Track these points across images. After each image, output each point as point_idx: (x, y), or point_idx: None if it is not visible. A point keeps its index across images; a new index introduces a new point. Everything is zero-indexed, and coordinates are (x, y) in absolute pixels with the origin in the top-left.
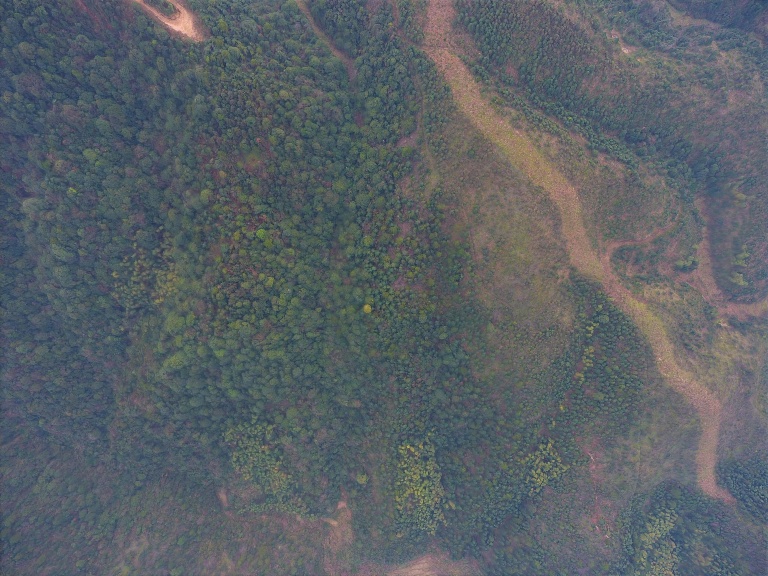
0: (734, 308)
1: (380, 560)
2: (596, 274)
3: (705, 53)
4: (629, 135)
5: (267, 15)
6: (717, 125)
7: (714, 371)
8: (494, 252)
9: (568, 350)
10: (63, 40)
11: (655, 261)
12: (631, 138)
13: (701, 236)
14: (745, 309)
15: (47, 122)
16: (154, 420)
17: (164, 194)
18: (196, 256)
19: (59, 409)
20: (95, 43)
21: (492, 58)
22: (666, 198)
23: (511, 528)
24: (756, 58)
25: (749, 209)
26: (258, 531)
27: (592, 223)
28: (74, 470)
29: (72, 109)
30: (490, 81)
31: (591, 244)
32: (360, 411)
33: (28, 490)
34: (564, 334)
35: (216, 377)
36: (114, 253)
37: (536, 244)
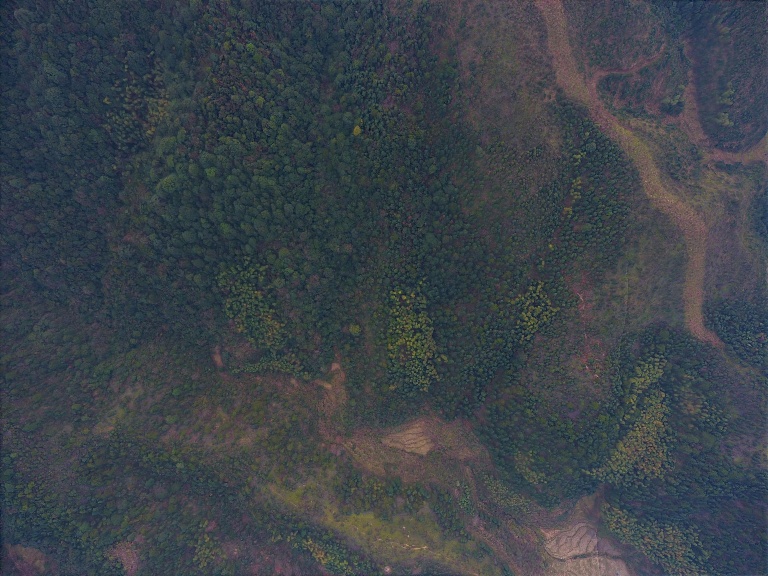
0: (720, 154)
1: (374, 420)
2: (582, 98)
3: None
4: None
5: None
6: None
7: (700, 197)
8: (481, 64)
9: (556, 178)
10: None
11: (641, 97)
12: None
13: (687, 78)
14: (731, 157)
15: None
16: (147, 253)
17: (154, 15)
18: (187, 73)
19: (53, 256)
20: None
21: None
22: (651, 23)
23: (503, 381)
24: None
25: (734, 44)
26: (252, 390)
27: (578, 43)
28: (69, 324)
29: None
30: None
31: (577, 65)
32: (352, 260)
33: (23, 338)
34: (552, 159)
35: (208, 208)
36: (105, 74)
37: (522, 54)
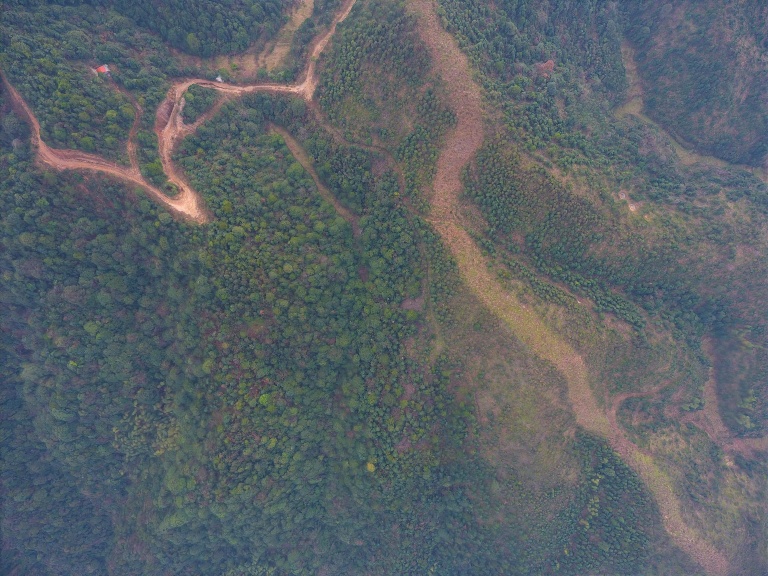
0: (740, 444)
1: None
2: (602, 430)
3: (713, 204)
4: (636, 289)
5: (271, 184)
6: (725, 278)
7: (721, 525)
8: (499, 419)
9: (573, 503)
10: (65, 224)
11: (661, 406)
12: (638, 292)
13: (707, 376)
14: (751, 443)
15: (48, 302)
16: None
17: (166, 353)
18: (198, 419)
19: (57, 547)
20: (97, 223)
21: (499, 228)
22: (673, 353)
23: None
24: (764, 207)
25: (756, 355)
26: None
27: (598, 383)
28: None
29: (73, 291)
30: (497, 254)
31: (597, 403)
32: None
33: None
34: (569, 489)
35: (217, 528)
36: (114, 413)
37: (542, 413)
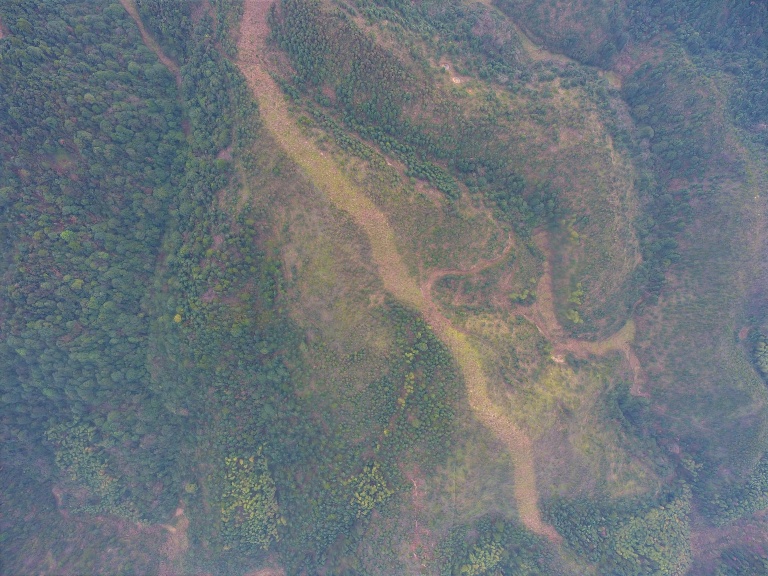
0: (574, 345)
1: (214, 571)
2: (414, 301)
3: (544, 89)
4: (458, 165)
5: (83, 17)
6: (548, 161)
7: (529, 407)
8: (299, 272)
9: (385, 375)
10: None
11: (487, 292)
12: (460, 168)
13: (541, 270)
14: (587, 346)
15: None
16: None
17: None
18: (2, 252)
19: None
20: None
21: (307, 78)
22: (490, 230)
23: (341, 549)
24: (597, 98)
25: (584, 247)
26: (90, 532)
27: (409, 250)
28: None
29: None
30: (300, 101)
31: (408, 271)
32: None
33: None
34: (379, 359)
35: (29, 375)
36: None
37: (340, 267)
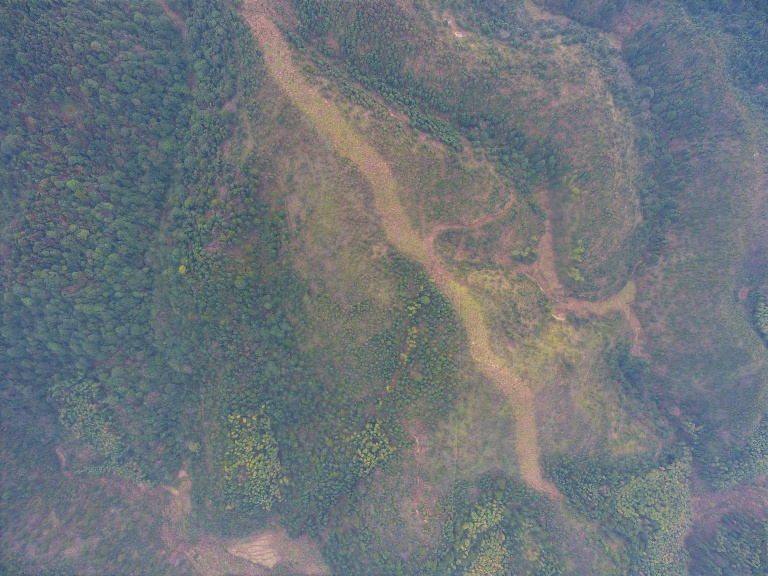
0: (575, 304)
1: (216, 532)
2: (417, 254)
3: (545, 45)
4: (460, 119)
5: None
6: (550, 116)
7: (531, 360)
8: (303, 221)
9: (388, 328)
10: None
11: (489, 248)
12: (462, 122)
13: (542, 229)
14: (588, 306)
15: None
16: None
17: None
18: (8, 202)
19: None
20: None
21: (311, 28)
22: (492, 184)
23: (344, 508)
24: (598, 55)
25: (585, 204)
26: (93, 493)
27: (411, 202)
28: None
29: None
30: (304, 49)
31: (411, 223)
32: None
33: None
34: (382, 311)
35: (34, 328)
36: None
37: (343, 215)
